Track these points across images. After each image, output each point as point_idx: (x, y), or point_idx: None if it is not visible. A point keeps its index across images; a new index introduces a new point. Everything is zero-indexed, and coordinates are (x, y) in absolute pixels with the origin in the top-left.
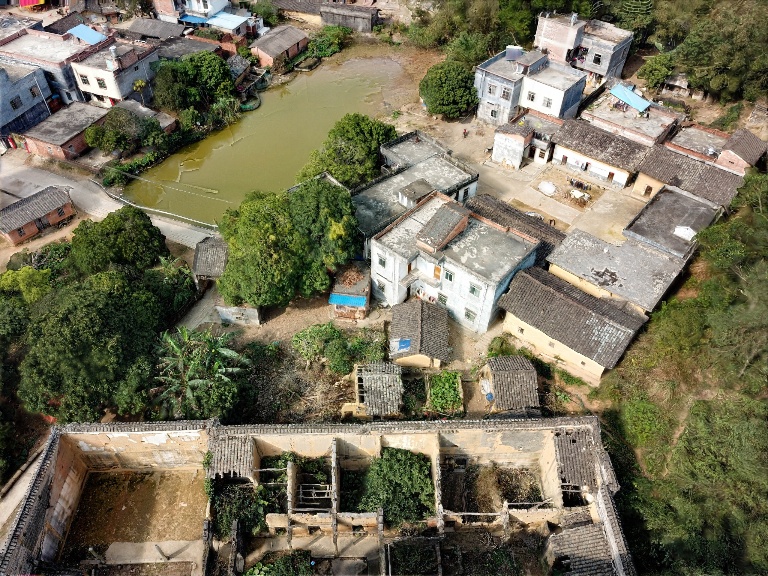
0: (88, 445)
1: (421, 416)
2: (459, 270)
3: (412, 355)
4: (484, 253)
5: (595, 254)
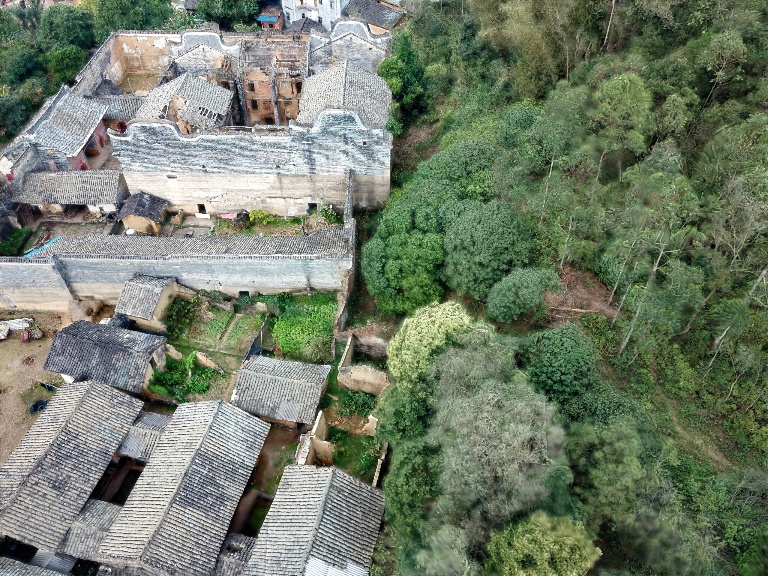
0: (128, 48)
1: None
2: None
3: None
4: None
5: None
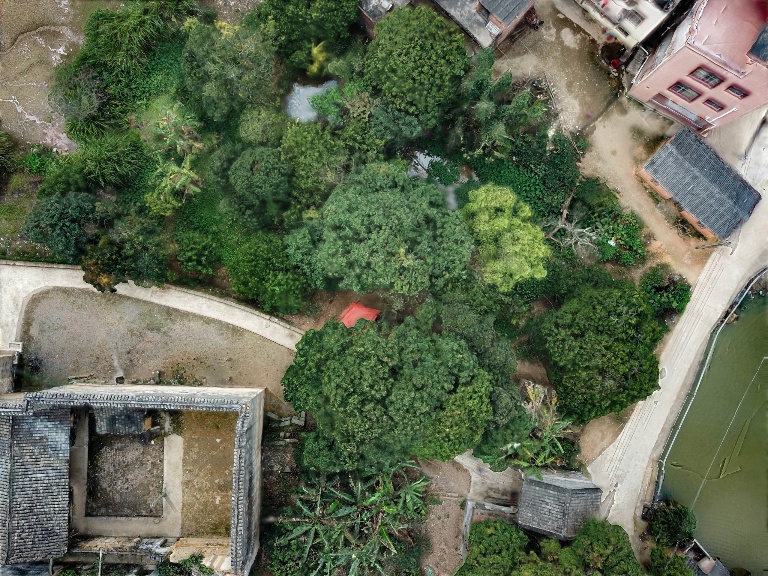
0: None
1: None
2: None
3: None
4: None
5: None
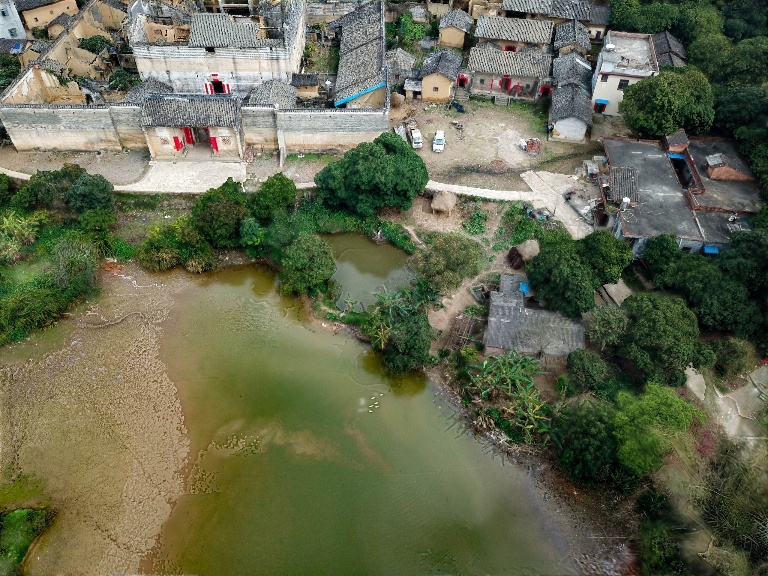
0: None
1: None
2: None
3: (26, 45)
4: None
5: None
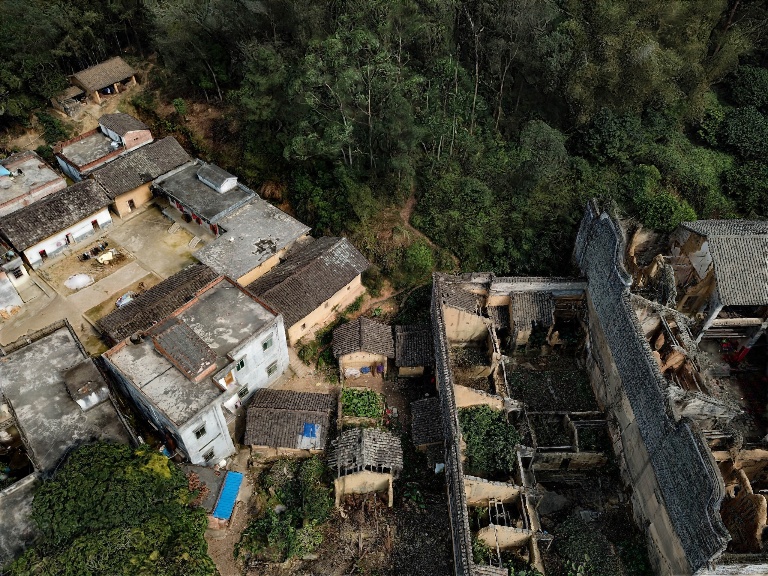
0: None
1: (387, 429)
2: (248, 346)
3: None
4: (227, 322)
5: (233, 248)
